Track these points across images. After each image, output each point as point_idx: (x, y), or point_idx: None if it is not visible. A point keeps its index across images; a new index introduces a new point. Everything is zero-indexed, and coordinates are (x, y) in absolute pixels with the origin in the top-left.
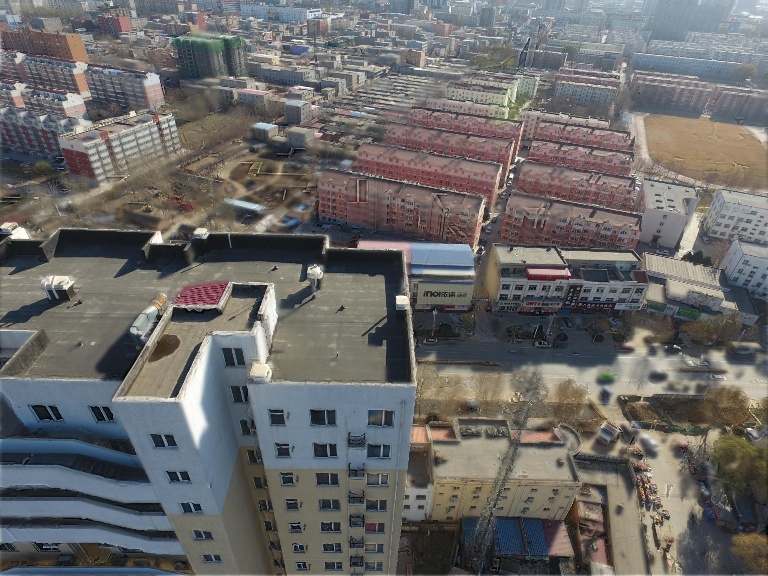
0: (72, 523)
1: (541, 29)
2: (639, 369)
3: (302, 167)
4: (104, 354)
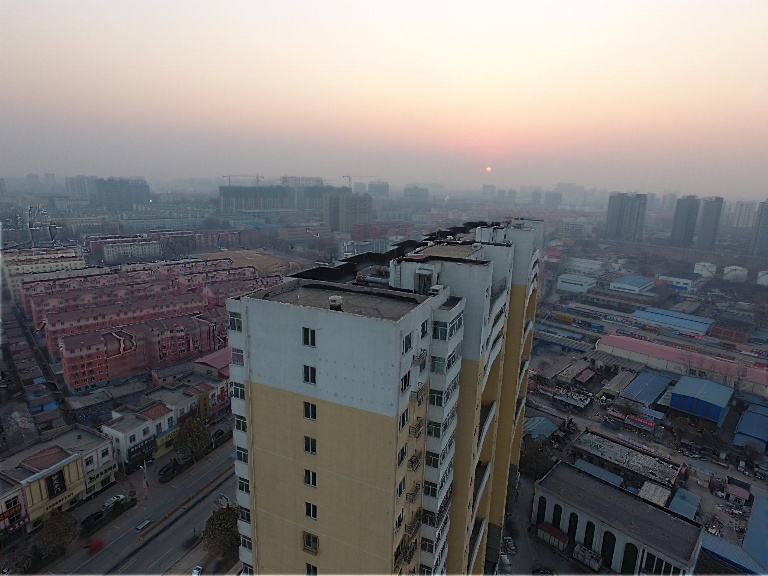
0: (534, 279)
1: (32, 209)
2: None
3: None
4: None
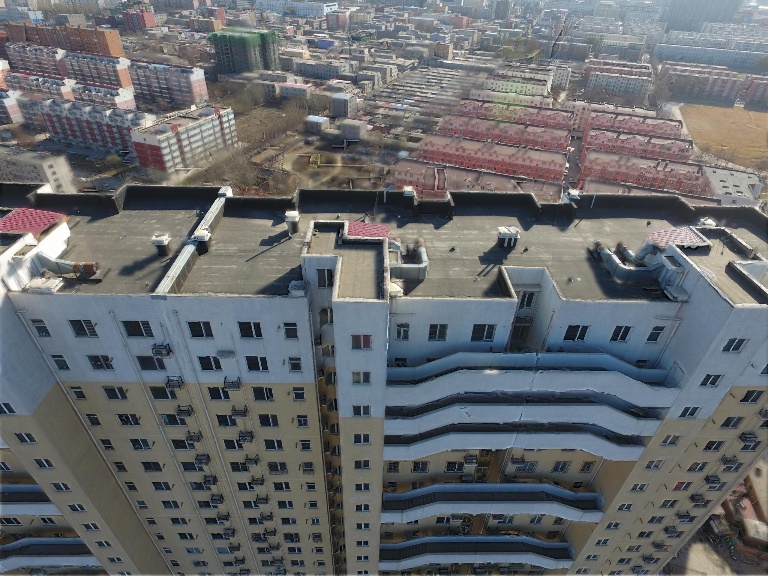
0: (566, 430)
1: (567, 21)
2: None
3: (360, 158)
4: (599, 287)
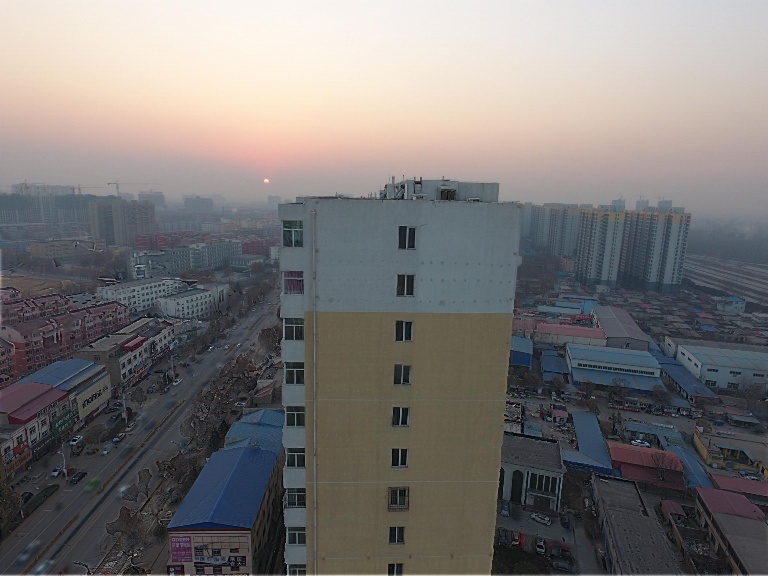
0: None
1: None
2: (220, 361)
3: None
4: None
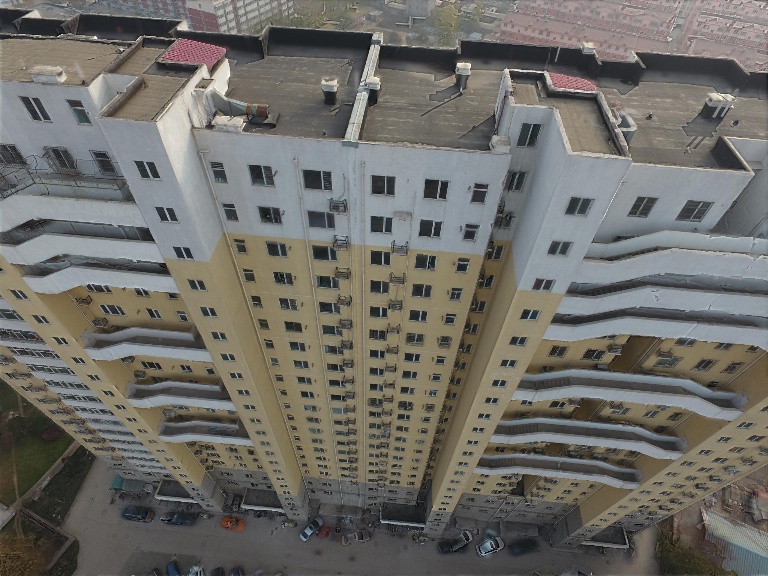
0: (751, 325)
1: None
2: None
3: (427, 39)
4: None
